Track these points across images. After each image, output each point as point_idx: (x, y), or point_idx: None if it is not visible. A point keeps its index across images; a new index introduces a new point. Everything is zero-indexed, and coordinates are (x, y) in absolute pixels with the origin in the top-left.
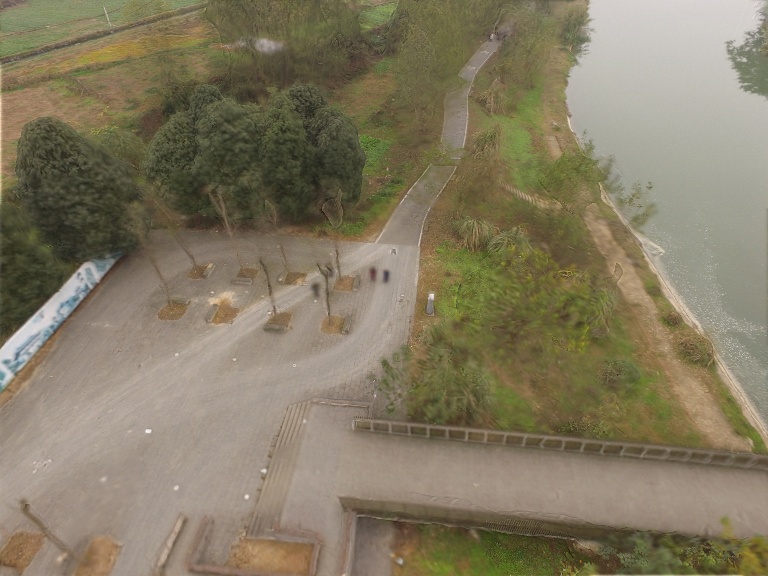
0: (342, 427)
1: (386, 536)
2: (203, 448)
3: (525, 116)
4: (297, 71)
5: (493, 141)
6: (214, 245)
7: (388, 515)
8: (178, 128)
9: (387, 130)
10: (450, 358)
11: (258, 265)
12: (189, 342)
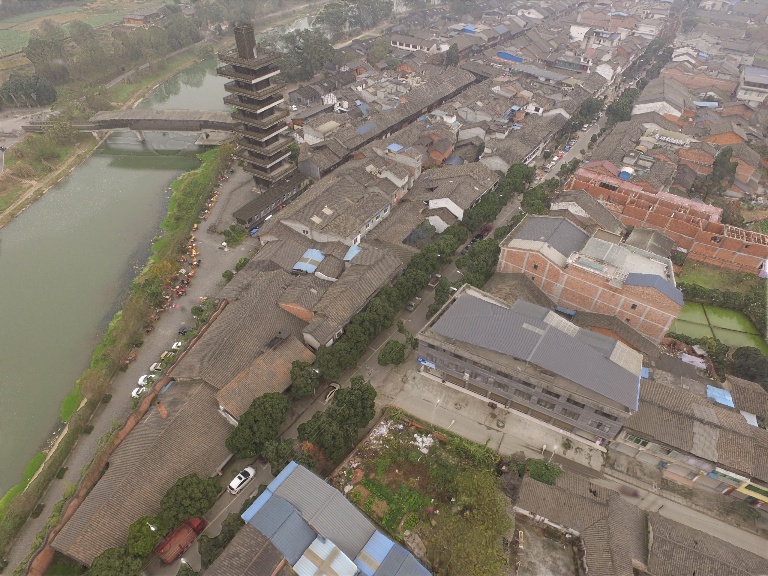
0: (28, 124)
1: None
2: (6, 128)
3: (141, 84)
4: (57, 71)
5: (102, 88)
6: (18, 109)
7: (30, 130)
8: (7, 83)
9: None
10: None
11: None
12: (7, 120)
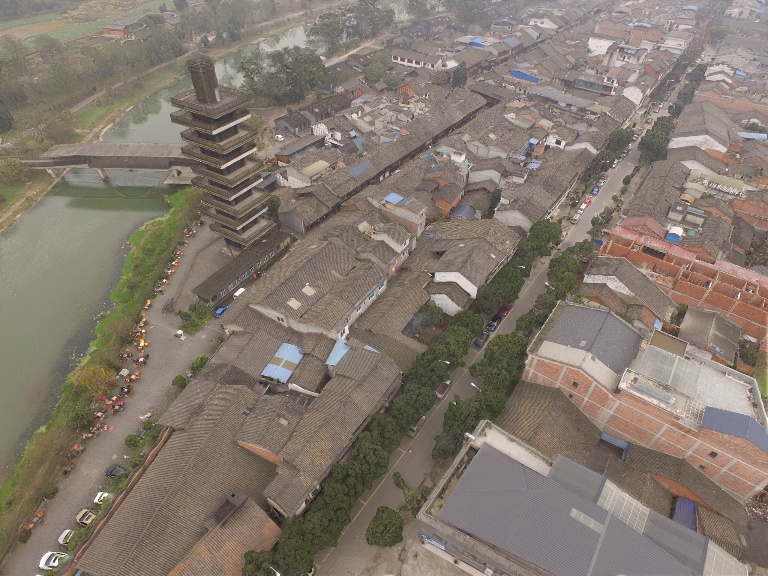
0: None
1: None
2: None
3: (112, 106)
4: (18, 93)
5: (66, 113)
6: None
7: None
8: None
9: (50, 112)
10: (1, 150)
11: None
12: None
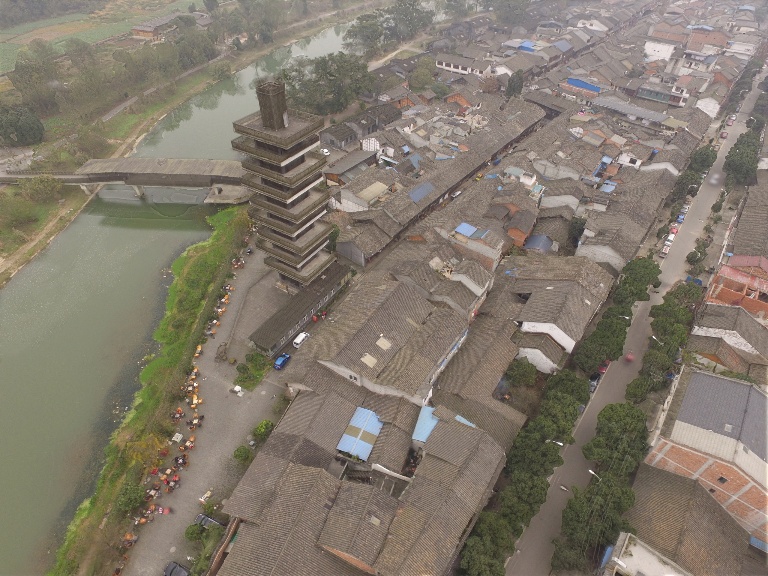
0: None
1: (5, 185)
2: None
3: (145, 114)
4: (48, 100)
5: (98, 123)
6: None
7: (6, 182)
8: None
9: (81, 120)
10: None
11: (7, 154)
12: None
